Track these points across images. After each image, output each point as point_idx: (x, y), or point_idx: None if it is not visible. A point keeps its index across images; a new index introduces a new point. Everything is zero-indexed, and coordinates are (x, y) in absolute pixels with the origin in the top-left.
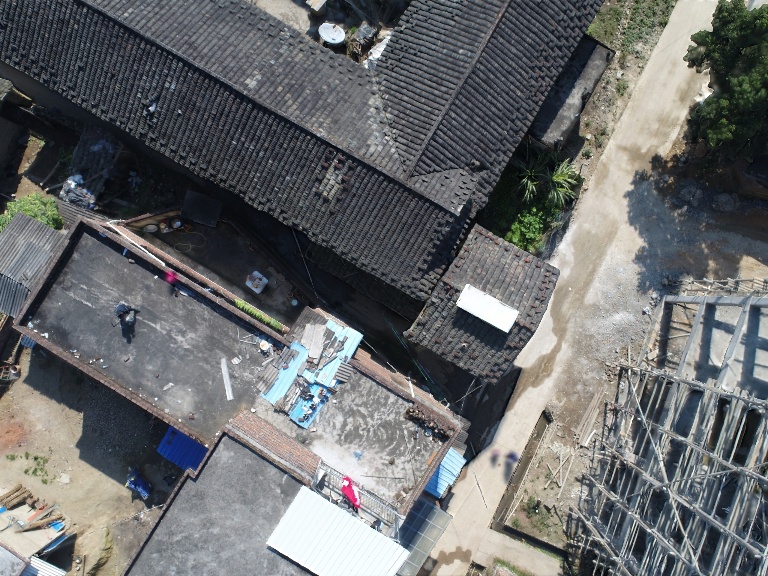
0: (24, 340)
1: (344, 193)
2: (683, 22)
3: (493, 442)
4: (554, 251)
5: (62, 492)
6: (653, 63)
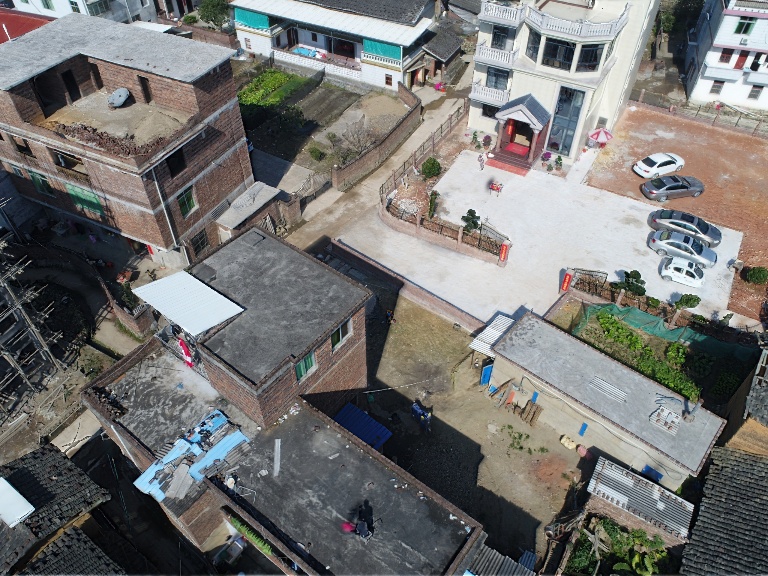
0: (534, 560)
1: None
2: None
3: None
4: None
5: (494, 417)
6: None
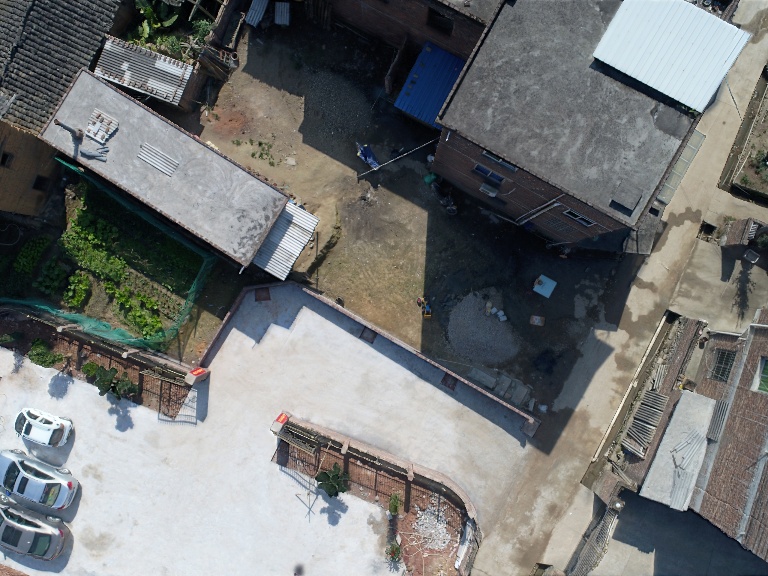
0: (248, 17)
1: None
2: None
3: (716, 101)
4: None
5: (290, 173)
6: None
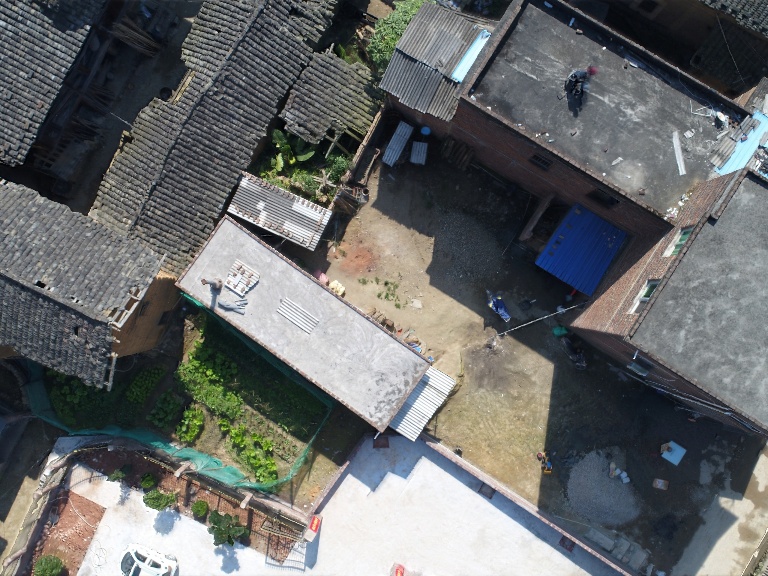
0: (385, 157)
1: None
2: None
3: None
4: None
5: (416, 317)
6: None
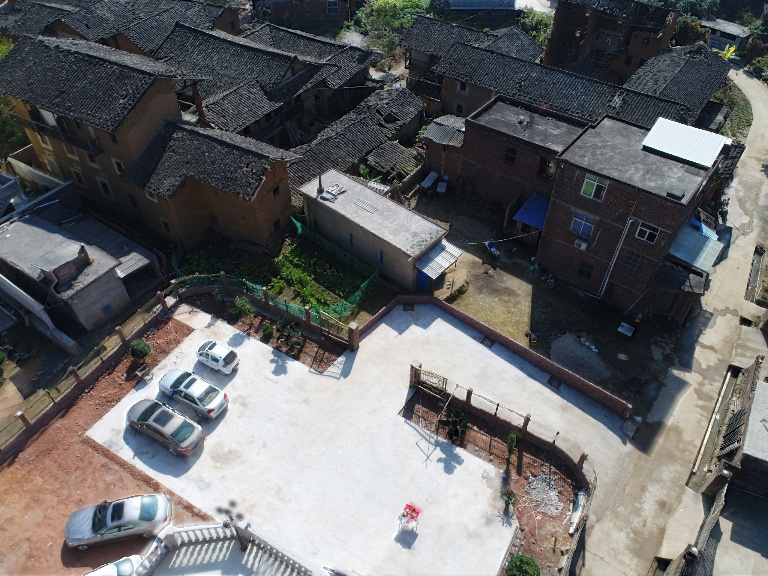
0: (422, 183)
1: (624, 104)
2: (760, 125)
3: (728, 258)
4: (729, 185)
5: None
6: (751, 135)
